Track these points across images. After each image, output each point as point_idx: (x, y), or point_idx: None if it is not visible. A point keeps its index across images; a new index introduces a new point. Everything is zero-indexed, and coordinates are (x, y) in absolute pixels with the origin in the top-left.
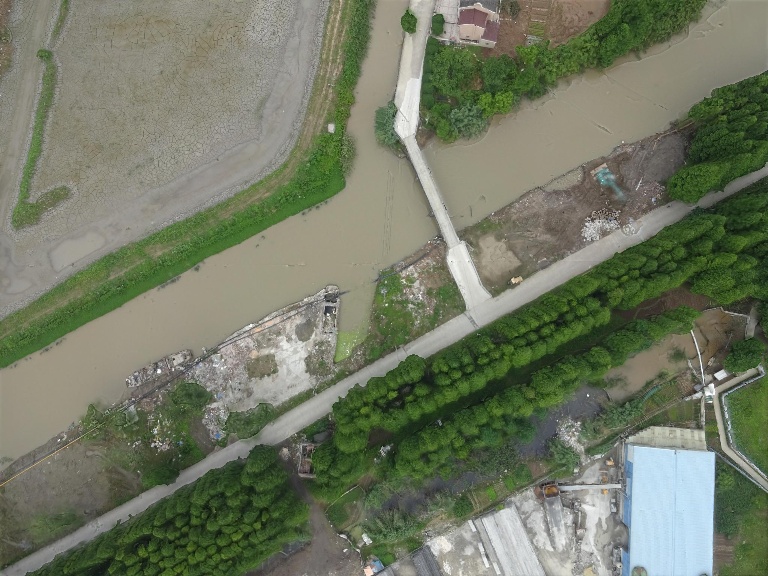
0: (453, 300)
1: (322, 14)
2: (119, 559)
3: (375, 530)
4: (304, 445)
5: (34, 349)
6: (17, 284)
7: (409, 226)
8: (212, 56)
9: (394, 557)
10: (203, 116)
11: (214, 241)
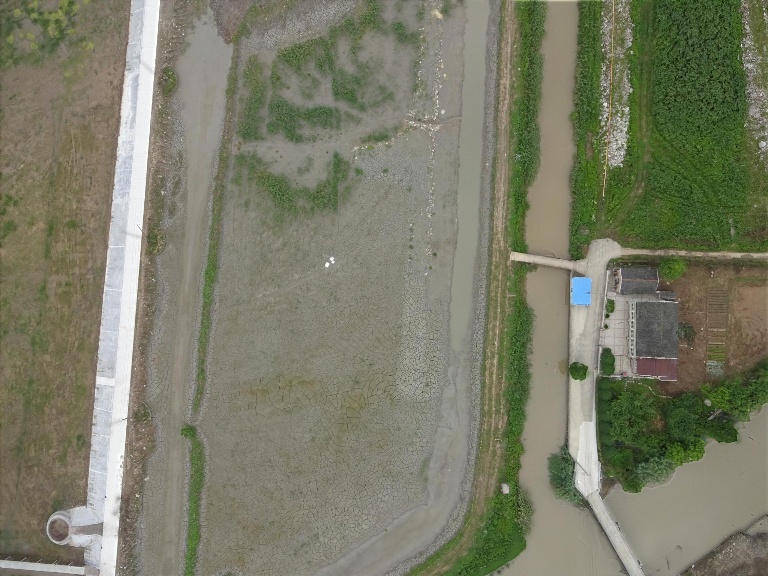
0: None
1: (477, 359)
2: None
3: None
4: None
5: None
6: None
7: None
8: (365, 416)
9: None
10: (364, 484)
11: None
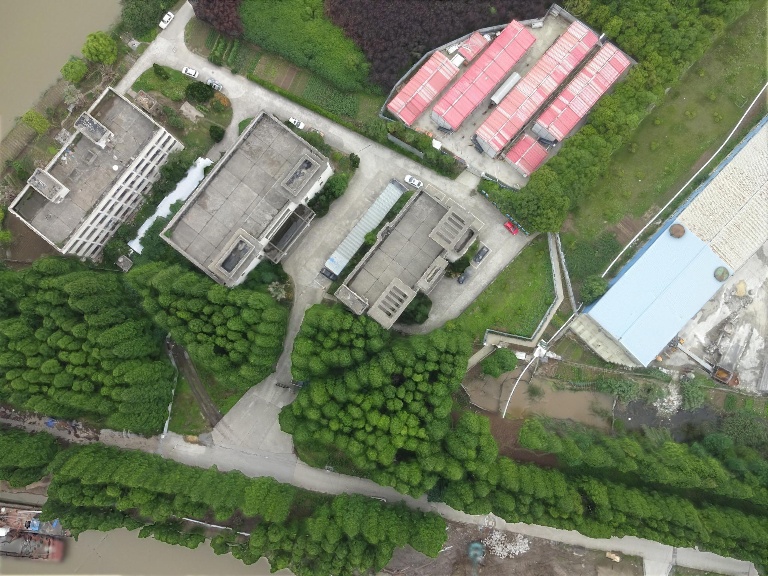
0: None
1: None
2: None
3: None
4: None
5: None
6: None
7: None
8: None
9: None
10: None
11: None
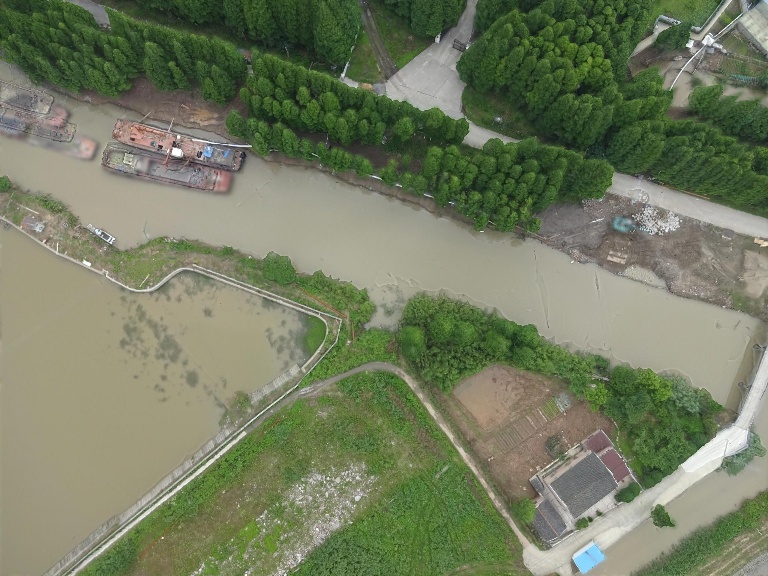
0: None
1: None
2: None
3: None
4: None
5: None
6: None
7: None
8: None
9: None
10: None
11: None
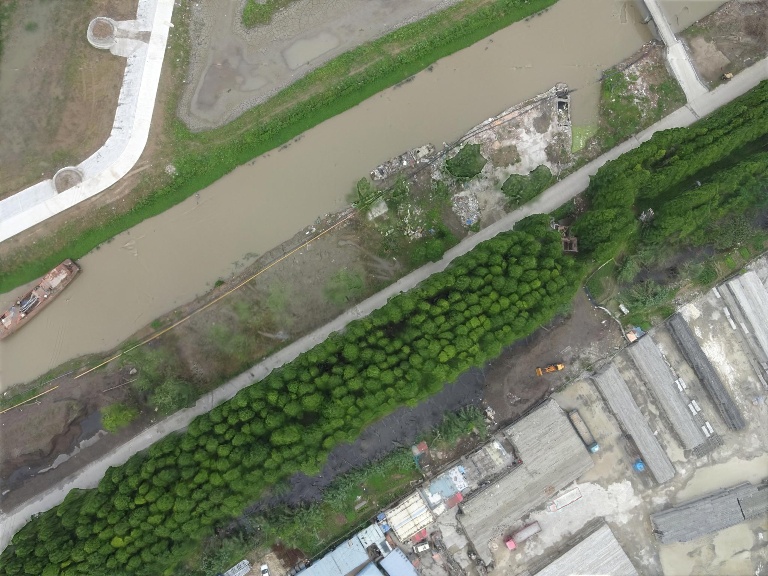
0: (674, 94)
1: None
2: (427, 308)
3: (630, 301)
4: (556, 225)
5: (273, 146)
6: (251, 82)
7: (624, 32)
8: None
9: (651, 325)
10: None
11: (449, 41)
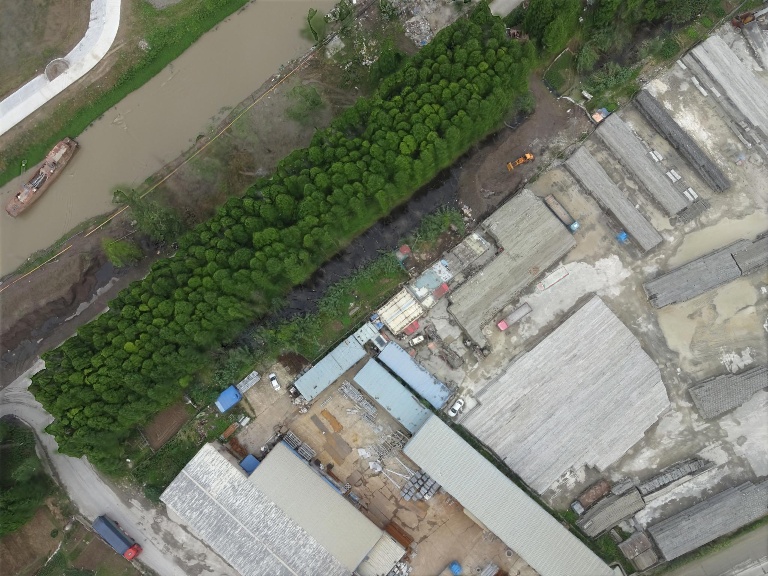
0: None
1: None
2: (380, 103)
3: None
4: (508, 29)
5: (232, 10)
6: None
7: None
8: None
9: (617, 105)
10: None
11: None
